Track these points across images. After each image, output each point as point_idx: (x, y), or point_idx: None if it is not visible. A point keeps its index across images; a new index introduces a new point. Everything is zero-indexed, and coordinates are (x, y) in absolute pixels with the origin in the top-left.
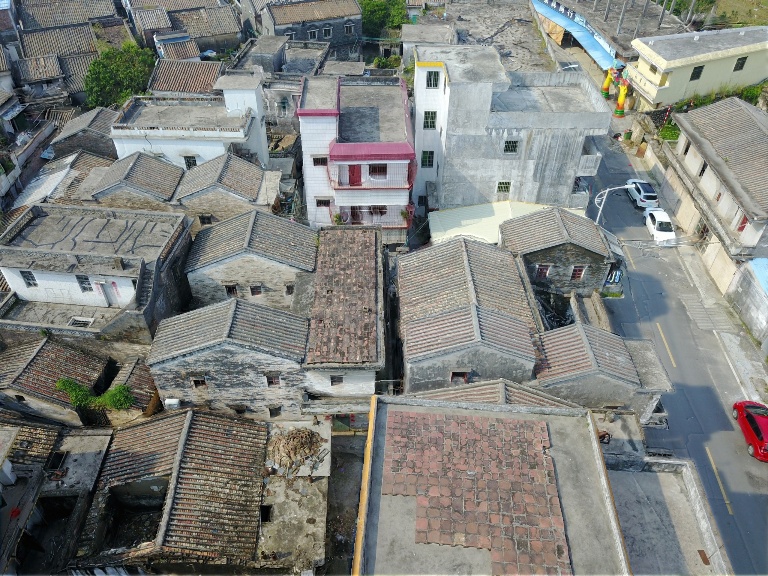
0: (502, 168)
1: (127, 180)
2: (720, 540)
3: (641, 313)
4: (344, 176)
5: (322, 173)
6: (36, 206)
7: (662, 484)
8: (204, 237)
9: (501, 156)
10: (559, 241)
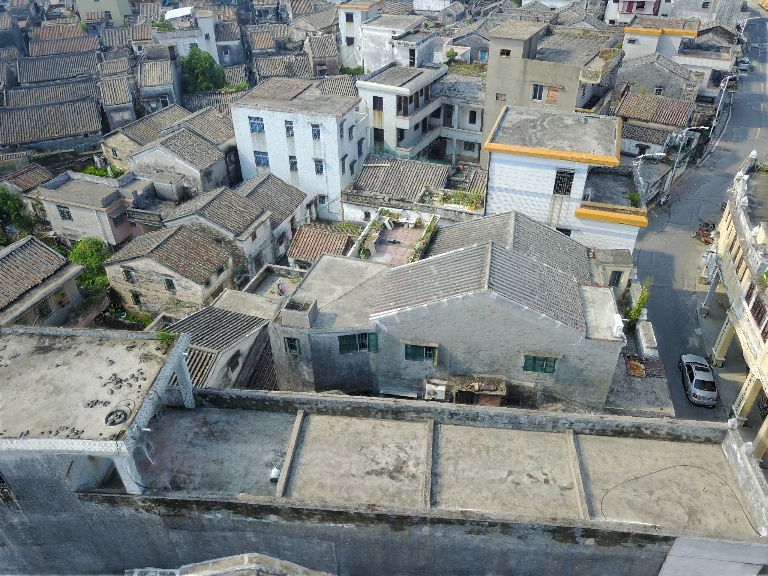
0: (700, 16)
1: (533, 5)
2: (732, 52)
3: (755, 80)
4: (624, 11)
5: (615, 7)
6: (500, 8)
7: (722, 53)
8: (563, 23)
9: (700, 10)
10: (715, 26)
